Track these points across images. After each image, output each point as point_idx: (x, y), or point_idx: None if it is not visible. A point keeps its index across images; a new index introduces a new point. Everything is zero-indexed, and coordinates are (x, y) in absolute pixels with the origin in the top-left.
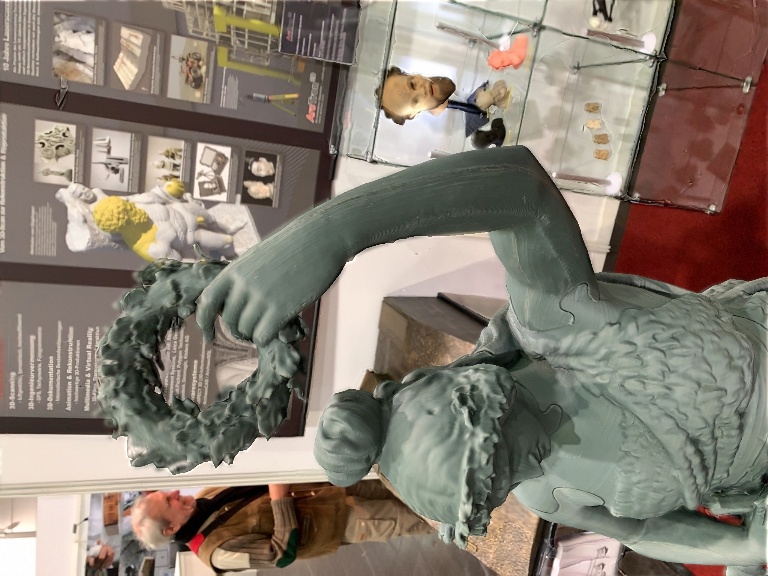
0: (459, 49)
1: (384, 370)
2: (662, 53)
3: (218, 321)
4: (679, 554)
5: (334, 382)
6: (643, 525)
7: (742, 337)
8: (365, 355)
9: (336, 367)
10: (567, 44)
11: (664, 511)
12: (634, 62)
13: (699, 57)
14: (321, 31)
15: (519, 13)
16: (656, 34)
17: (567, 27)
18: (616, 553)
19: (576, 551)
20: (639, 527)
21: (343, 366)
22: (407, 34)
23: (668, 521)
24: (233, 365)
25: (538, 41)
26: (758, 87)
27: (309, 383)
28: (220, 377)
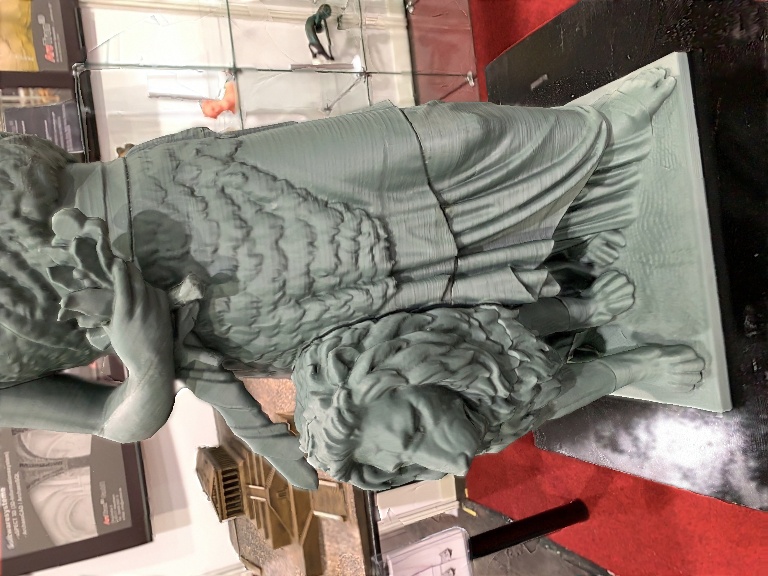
0: (211, 121)
1: (220, 443)
2: (368, 68)
3: (20, 439)
4: (122, 418)
5: (180, 474)
6: (103, 406)
7: (17, 147)
8: (206, 436)
9: (178, 457)
10: (318, 93)
11: (1, 350)
12: (355, 84)
13: (450, 77)
14: (45, 130)
15: (209, 63)
16: (359, 54)
17: (261, 64)
18: (463, 552)
19: (411, 561)
20: (96, 408)
21: (186, 455)
22: (153, 119)
23: (116, 390)
24: (49, 482)
25: (237, 82)
26: (478, 77)
27: (143, 480)
28: (36, 499)
